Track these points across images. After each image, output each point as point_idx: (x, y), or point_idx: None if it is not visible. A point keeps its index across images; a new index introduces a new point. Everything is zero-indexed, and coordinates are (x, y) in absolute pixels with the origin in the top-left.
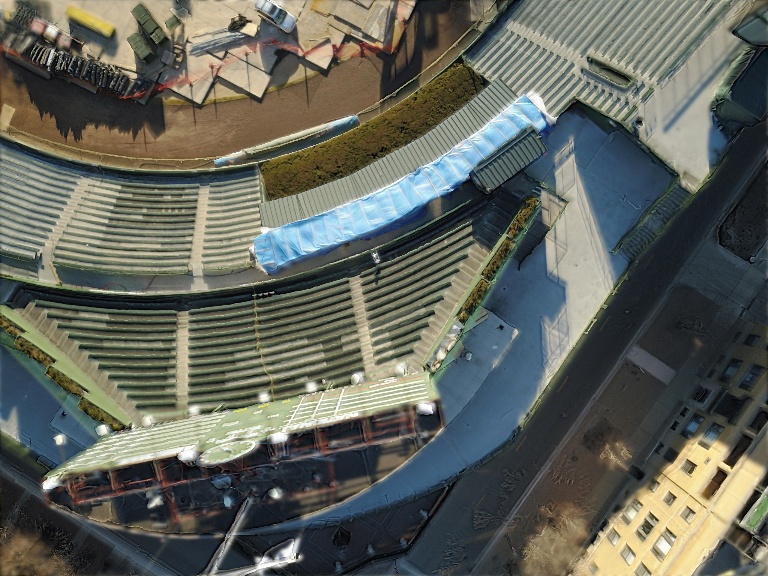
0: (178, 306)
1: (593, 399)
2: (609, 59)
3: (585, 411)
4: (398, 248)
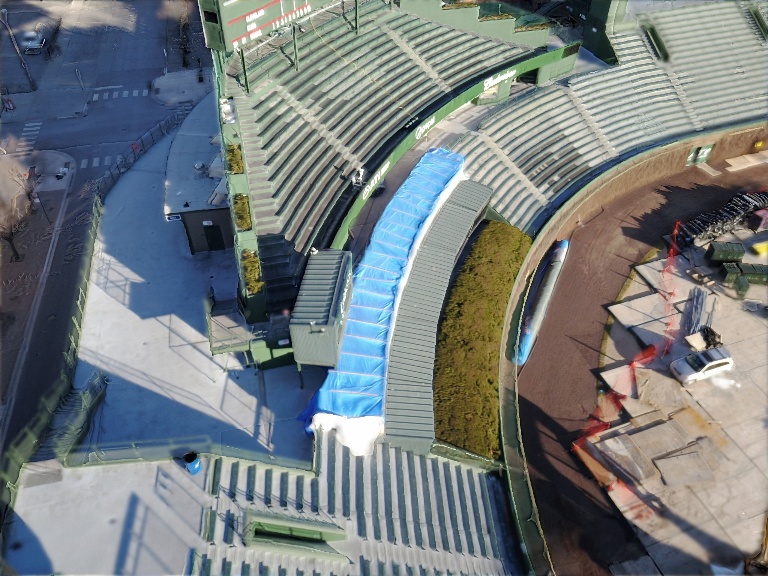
0: (456, 93)
1: (25, 348)
2: (319, 572)
3: (29, 334)
4: (348, 205)
